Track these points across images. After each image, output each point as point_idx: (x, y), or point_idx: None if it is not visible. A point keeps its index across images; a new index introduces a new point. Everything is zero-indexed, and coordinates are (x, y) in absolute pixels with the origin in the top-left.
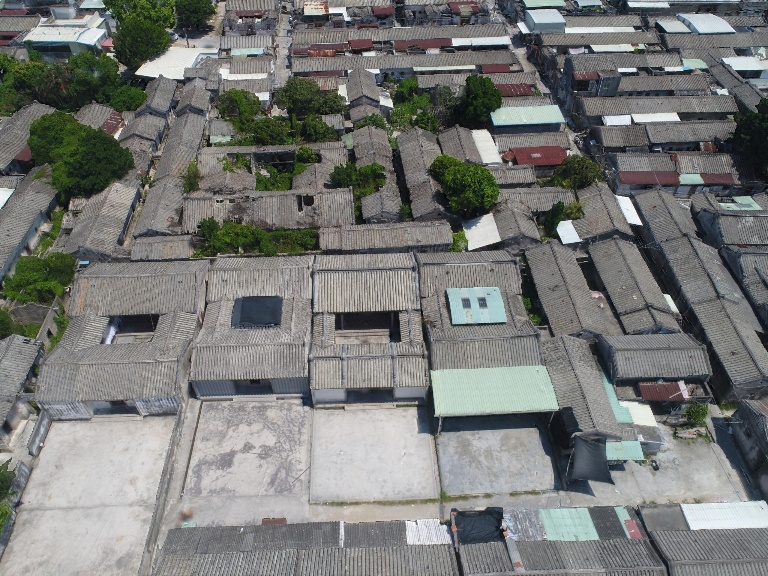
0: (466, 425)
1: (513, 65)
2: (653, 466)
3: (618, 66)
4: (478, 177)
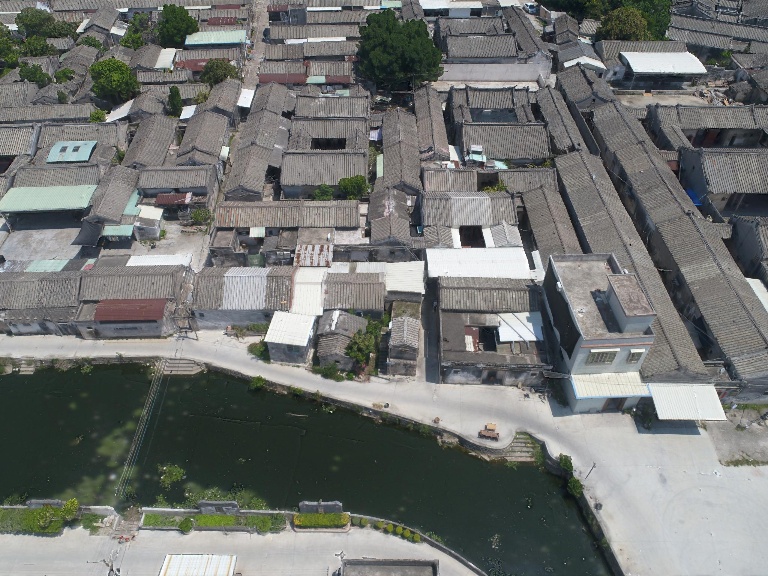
0: (36, 227)
1: (245, 6)
2: (151, 246)
3: (326, 5)
4: (108, 66)
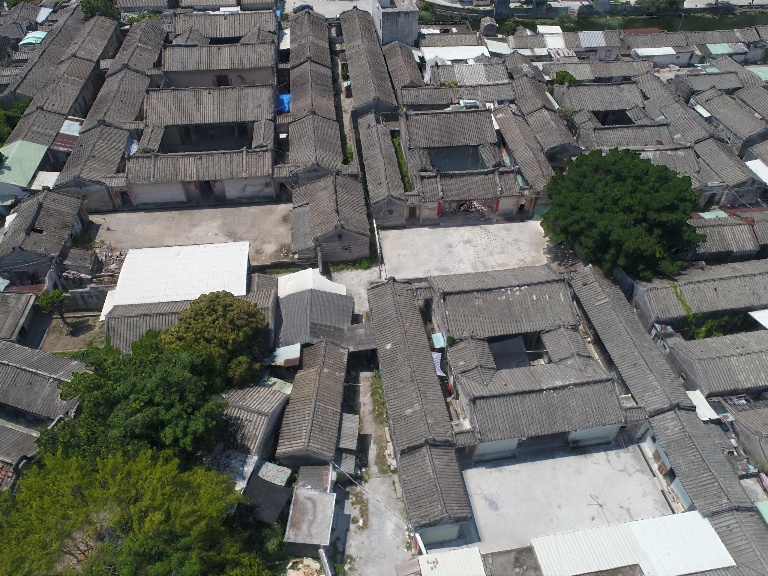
0: None
1: None
2: None
3: None
4: None
